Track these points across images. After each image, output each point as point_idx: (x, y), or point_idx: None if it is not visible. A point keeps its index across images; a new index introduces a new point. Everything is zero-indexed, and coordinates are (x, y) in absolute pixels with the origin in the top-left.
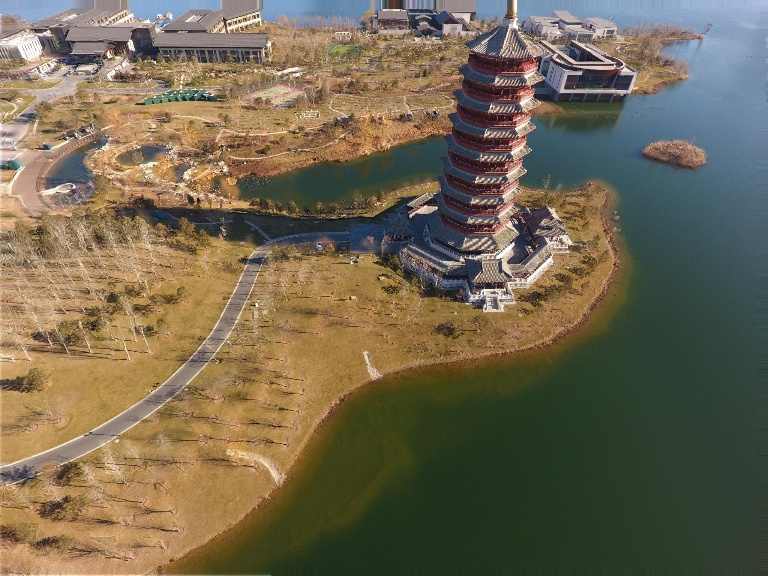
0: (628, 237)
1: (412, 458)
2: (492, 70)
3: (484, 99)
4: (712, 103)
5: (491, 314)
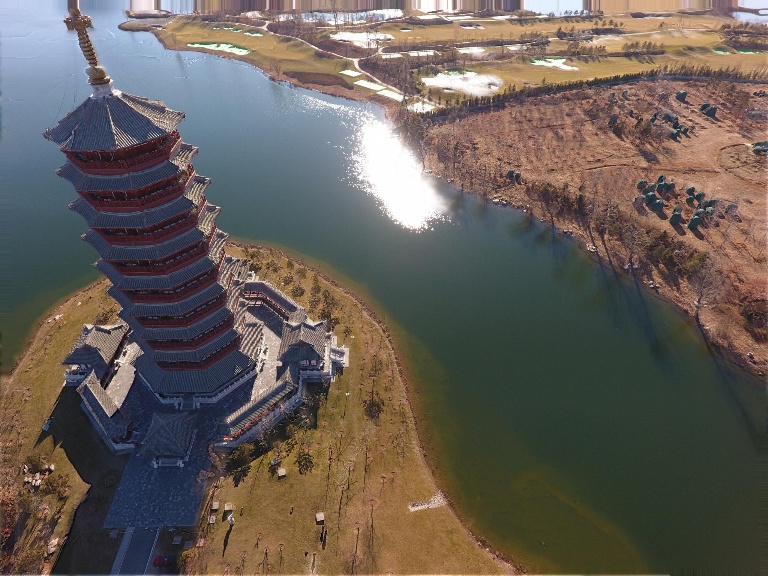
0: (232, 234)
1: (536, 468)
2: (159, 157)
3: (171, 197)
4: (17, 107)
5: (352, 361)
